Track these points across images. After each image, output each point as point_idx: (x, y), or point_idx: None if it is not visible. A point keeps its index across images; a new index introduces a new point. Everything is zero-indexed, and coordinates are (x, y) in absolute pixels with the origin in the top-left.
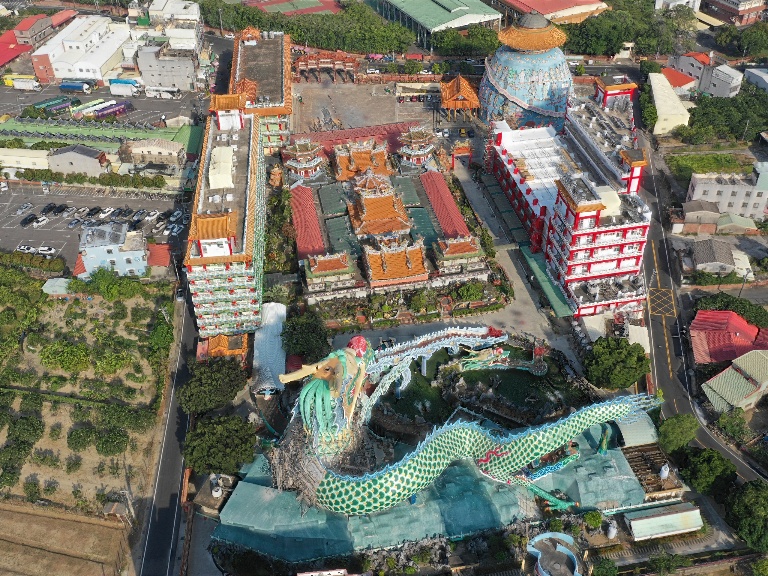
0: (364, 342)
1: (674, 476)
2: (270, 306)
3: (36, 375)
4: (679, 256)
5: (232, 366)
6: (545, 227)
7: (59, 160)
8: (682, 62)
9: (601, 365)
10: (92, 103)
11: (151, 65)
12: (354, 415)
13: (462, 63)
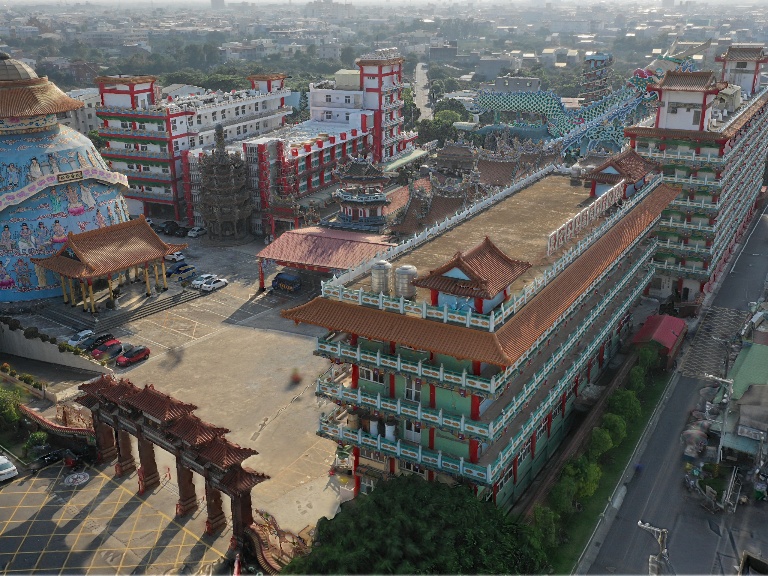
0: None
1: None
2: None
3: None
4: None
5: None
6: None
7: None
8: None
9: None
10: None
11: None
12: None
13: None
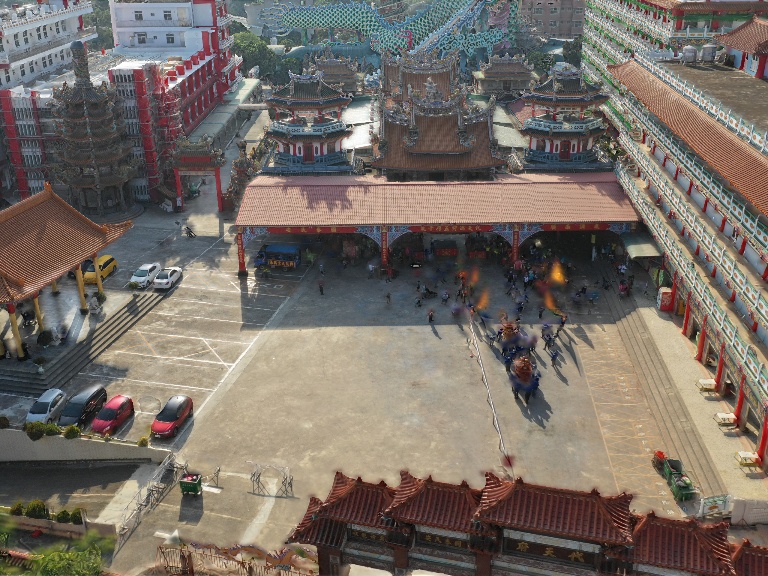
0: None
1: None
2: None
3: None
4: None
5: None
6: None
7: None
8: None
9: (267, 47)
10: None
11: None
12: None
13: None
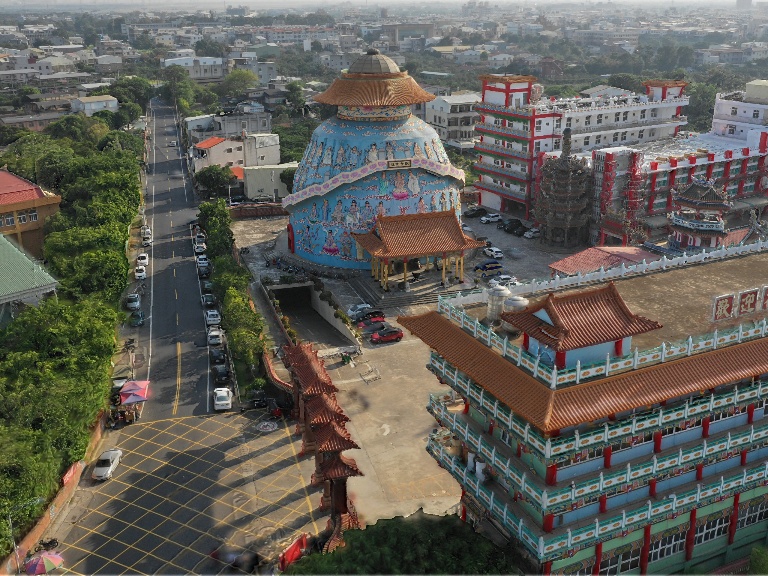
0: None
1: None
2: None
3: None
4: None
5: None
6: (767, 161)
7: None
8: (215, 155)
9: None
10: None
11: None
12: None
13: (231, 263)
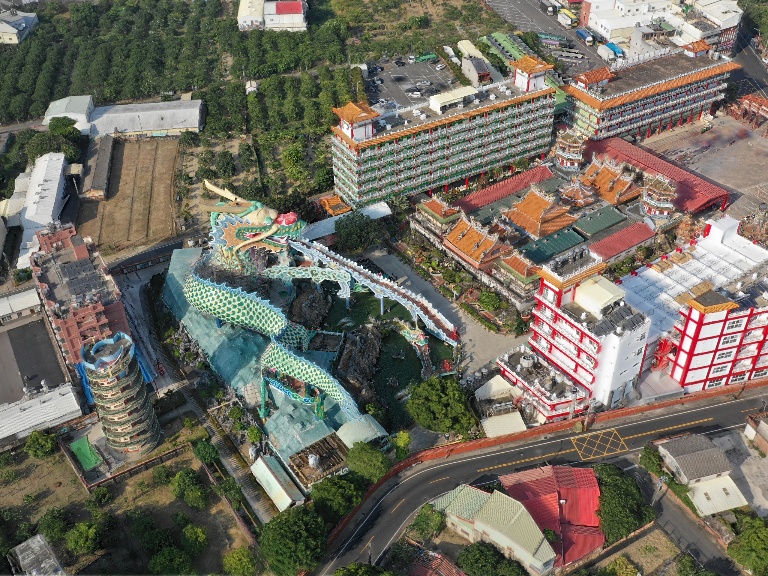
0: (291, 218)
1: (319, 473)
2: (382, 204)
3: (277, 156)
4: (677, 434)
5: (303, 208)
6: None
7: (466, 64)
8: None
9: None
10: (568, 49)
11: (638, 43)
12: (265, 263)
13: None
